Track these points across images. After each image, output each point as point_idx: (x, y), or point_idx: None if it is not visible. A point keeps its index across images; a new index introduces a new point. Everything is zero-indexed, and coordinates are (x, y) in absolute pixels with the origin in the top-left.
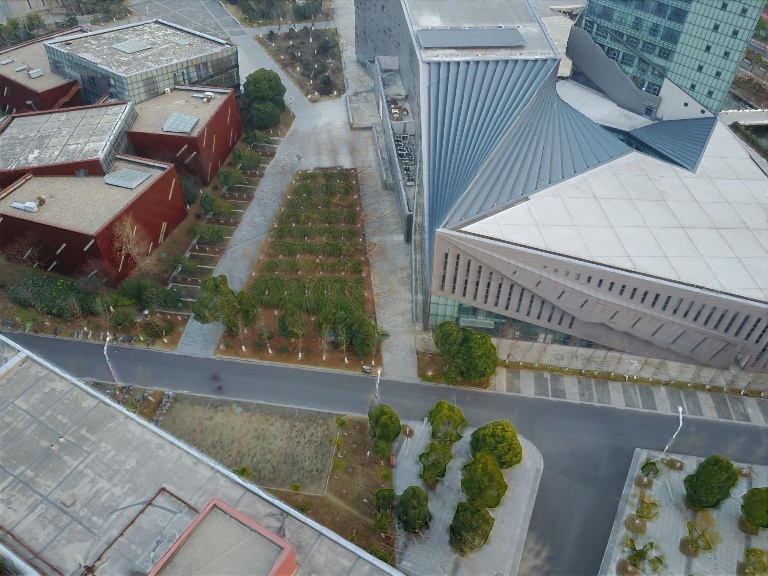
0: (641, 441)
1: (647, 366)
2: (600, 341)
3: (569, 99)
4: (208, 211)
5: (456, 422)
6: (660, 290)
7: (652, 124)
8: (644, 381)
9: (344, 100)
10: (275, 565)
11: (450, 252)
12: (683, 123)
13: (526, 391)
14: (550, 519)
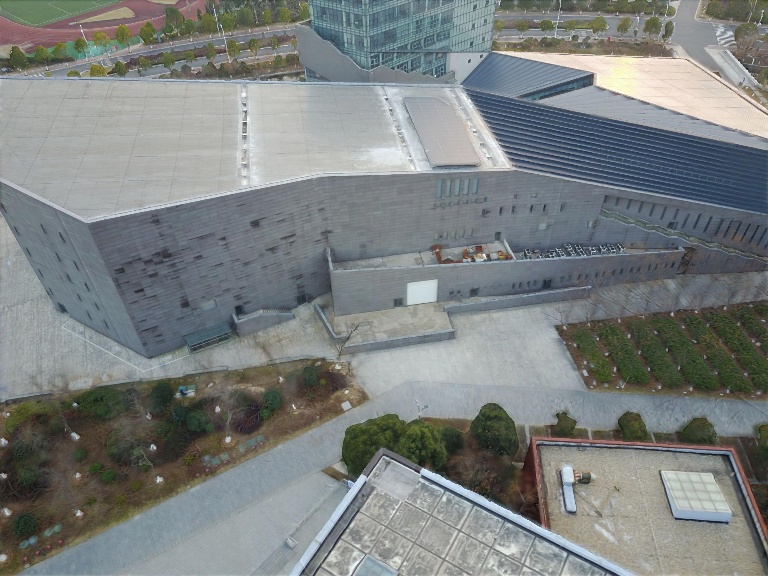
0: None
1: None
2: None
3: None
4: None
5: None
6: None
7: None
8: None
9: (355, 356)
10: None
11: None
12: (482, 73)
13: None
14: None
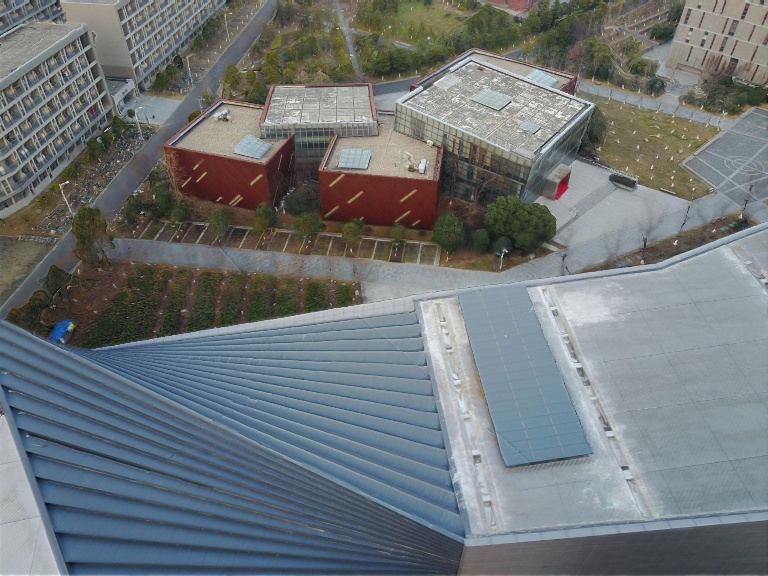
0: None
1: None
2: None
3: None
4: None
5: None
6: None
7: None
8: None
9: None
10: None
11: None
12: None
13: None
14: None
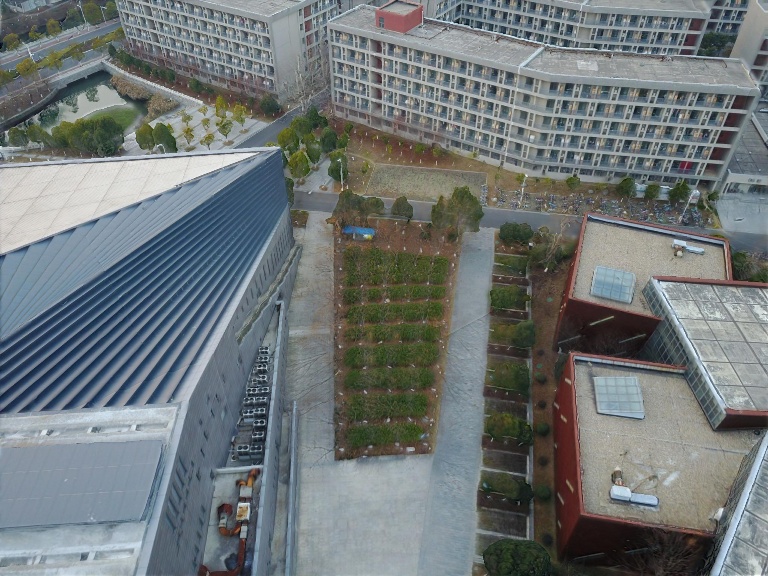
0: None
1: None
2: None
3: None
4: None
5: None
6: None
7: None
8: None
9: None
10: None
11: None
12: None
13: None
14: None
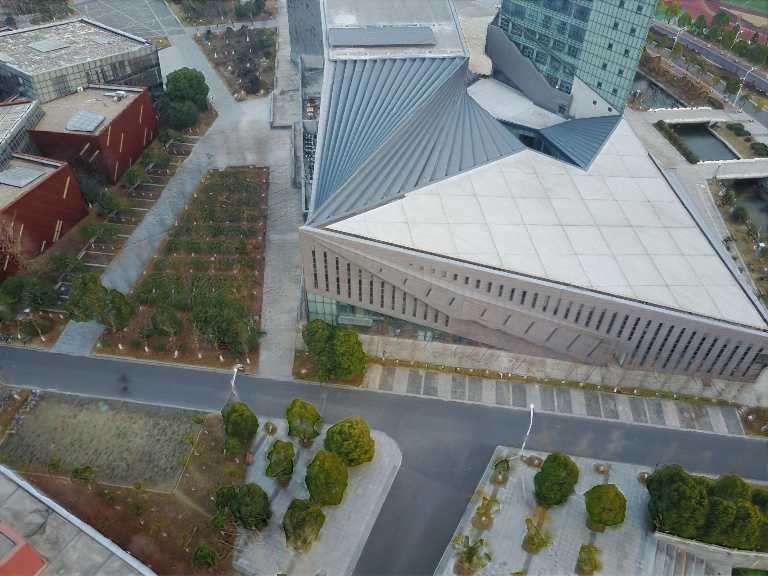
0: (504, 438)
1: (525, 364)
2: (478, 339)
3: (486, 97)
4: (109, 210)
5: (308, 420)
6: (526, 287)
7: (564, 122)
8: (518, 379)
9: (270, 99)
10: (1, 561)
11: (316, 250)
12: (591, 121)
13: (398, 389)
14: (397, 516)
